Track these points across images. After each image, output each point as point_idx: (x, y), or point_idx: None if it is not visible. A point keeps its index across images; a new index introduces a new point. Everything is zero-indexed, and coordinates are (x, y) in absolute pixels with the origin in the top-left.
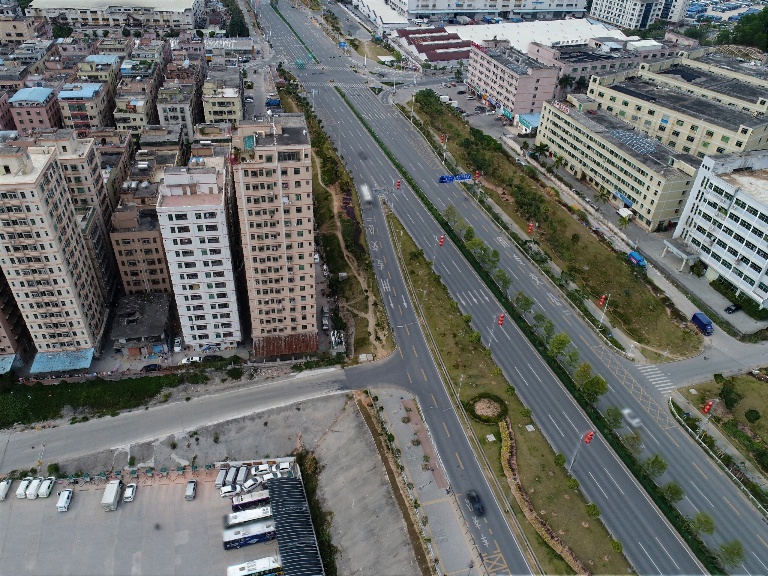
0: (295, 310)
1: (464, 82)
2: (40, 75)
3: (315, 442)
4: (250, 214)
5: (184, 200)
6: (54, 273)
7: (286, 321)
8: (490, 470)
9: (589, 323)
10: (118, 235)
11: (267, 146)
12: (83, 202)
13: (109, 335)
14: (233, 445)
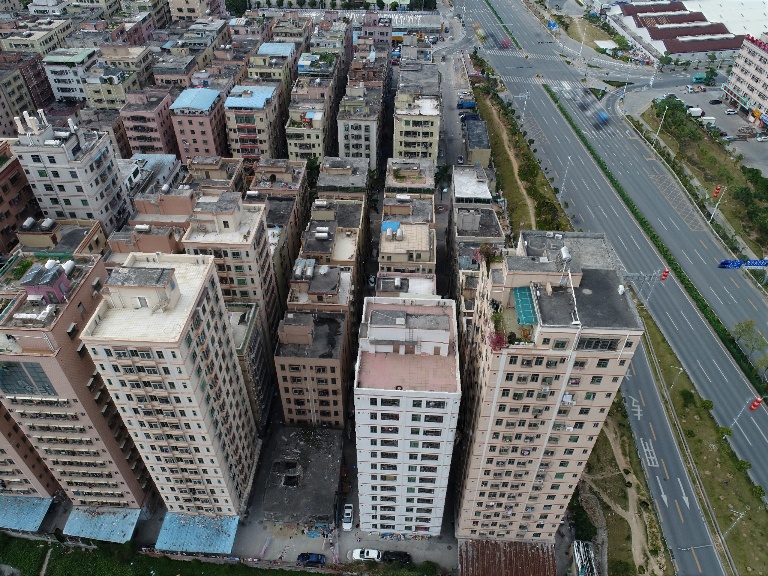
0: (530, 518)
1: (721, 87)
2: (207, 72)
3: None
4: (501, 409)
5: (395, 367)
6: (196, 441)
7: (511, 526)
8: None
9: None
10: (285, 359)
11: (564, 327)
12: (243, 295)
13: (259, 479)
14: None
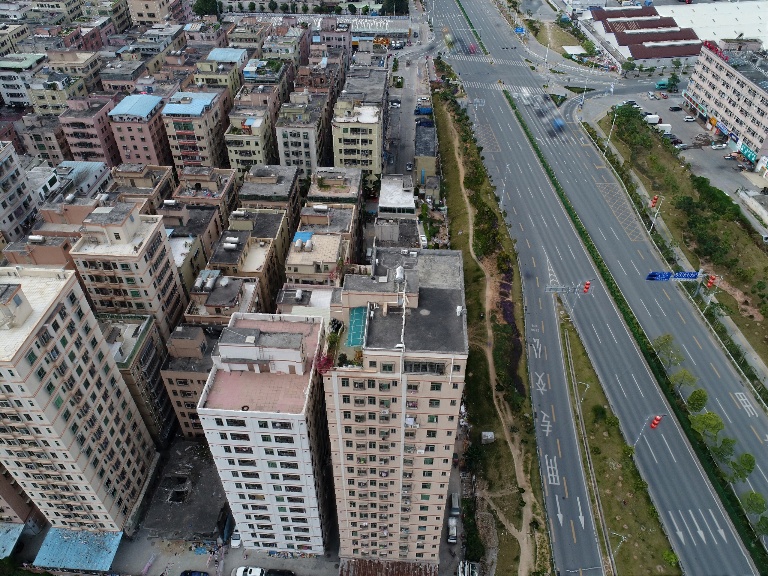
0: (407, 539)
1: (682, 94)
2: (151, 78)
3: None
4: (347, 431)
5: (247, 386)
6: (59, 458)
7: (392, 546)
8: None
9: None
10: (171, 373)
11: (386, 350)
12: (139, 307)
13: None
14: None
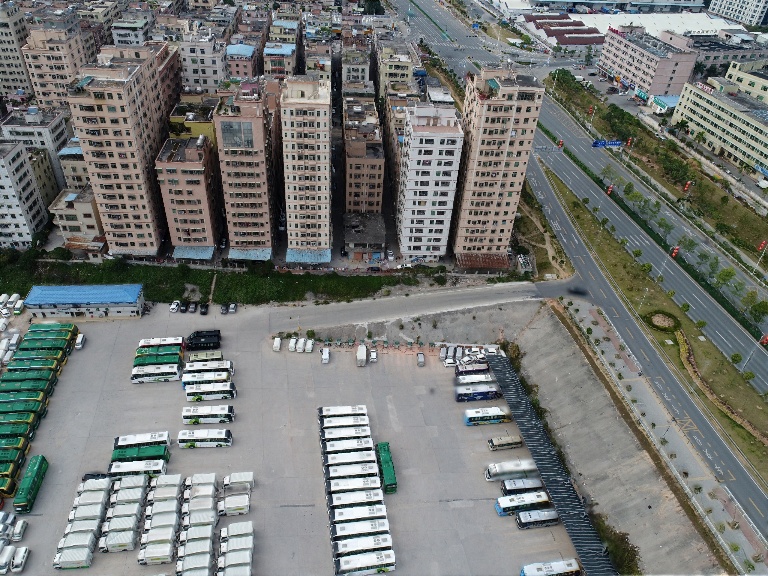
0: (495, 232)
1: (595, 65)
2: (242, 34)
3: (514, 336)
4: (482, 144)
5: (429, 129)
6: (320, 181)
7: (485, 241)
8: (672, 364)
9: (743, 268)
10: (353, 160)
11: (511, 86)
12: None
13: None
14: (448, 331)
